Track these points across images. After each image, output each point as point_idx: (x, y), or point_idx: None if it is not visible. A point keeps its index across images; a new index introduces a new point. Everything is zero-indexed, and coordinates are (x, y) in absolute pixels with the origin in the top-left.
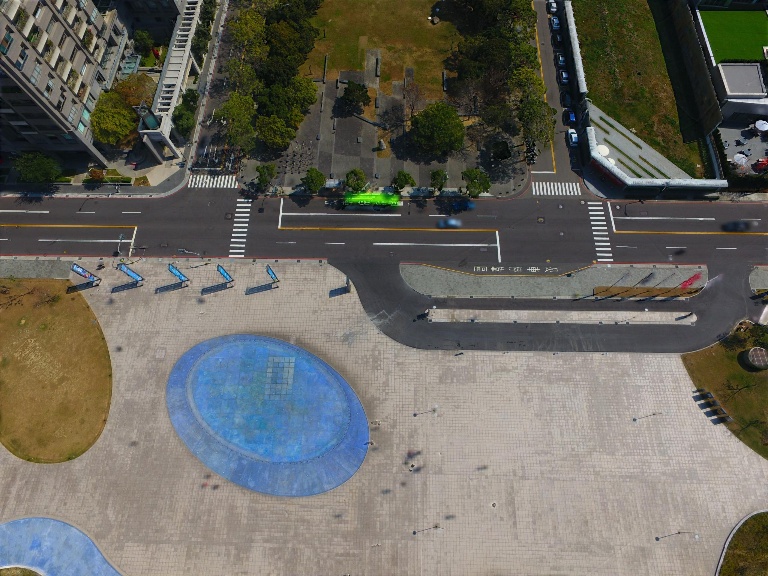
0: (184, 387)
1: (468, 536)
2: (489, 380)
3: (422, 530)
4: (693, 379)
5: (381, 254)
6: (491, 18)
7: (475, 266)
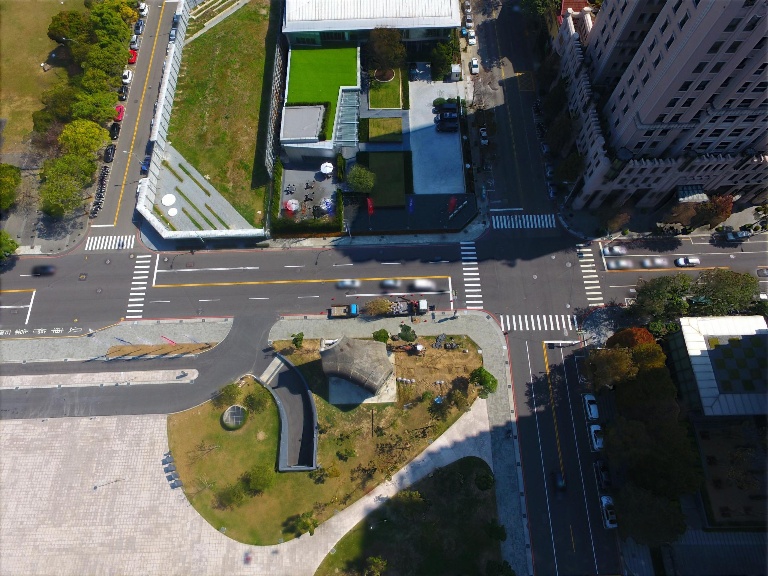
0: None
1: None
2: None
3: None
4: (169, 441)
5: None
6: None
7: None
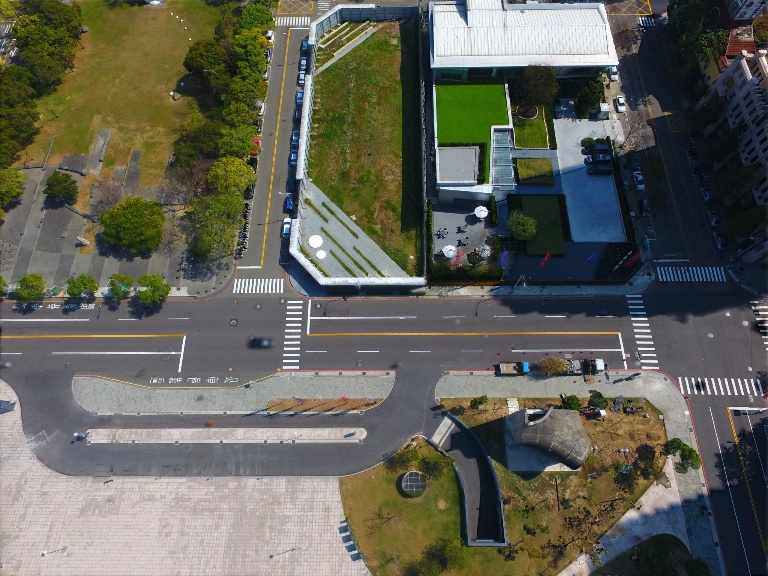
0: None
1: None
2: (132, 511)
3: None
4: (344, 507)
5: (57, 365)
6: None
7: (152, 377)
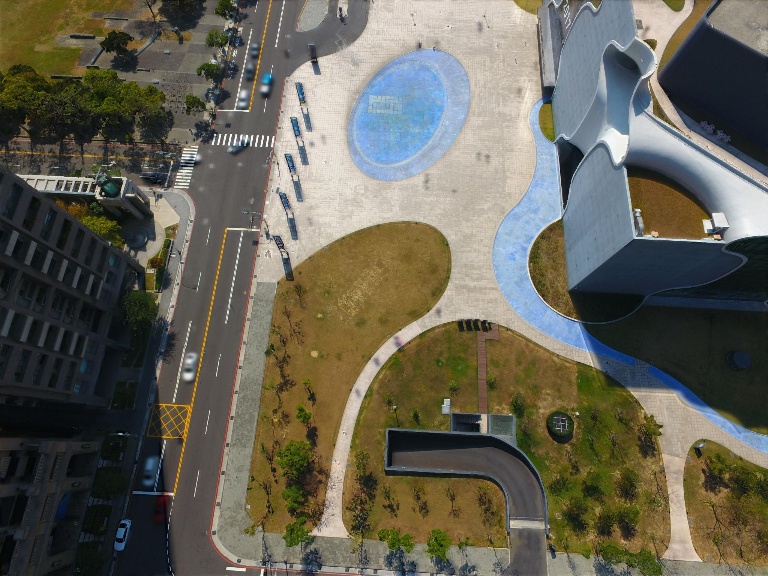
0: (390, 169)
1: (489, 2)
2: None
3: (487, 23)
4: None
5: (286, 42)
6: None
7: None
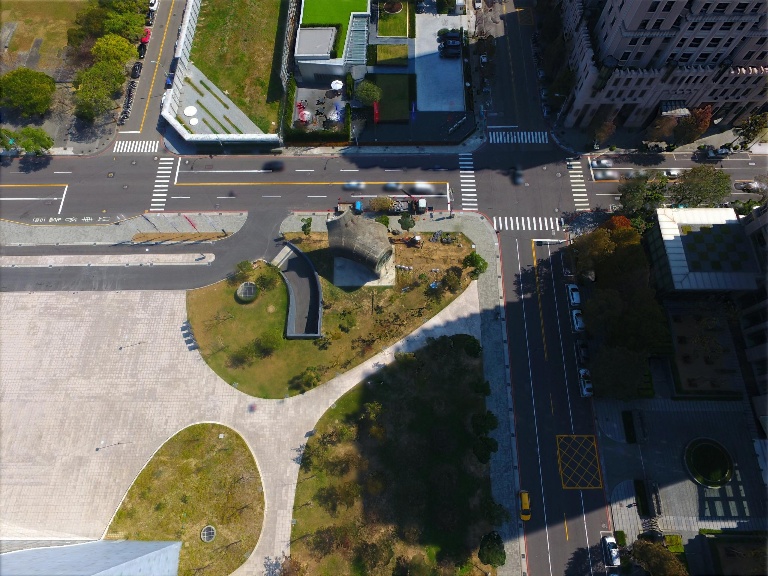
0: None
1: None
2: (6, 317)
3: None
4: (188, 312)
5: None
6: None
7: (35, 217)
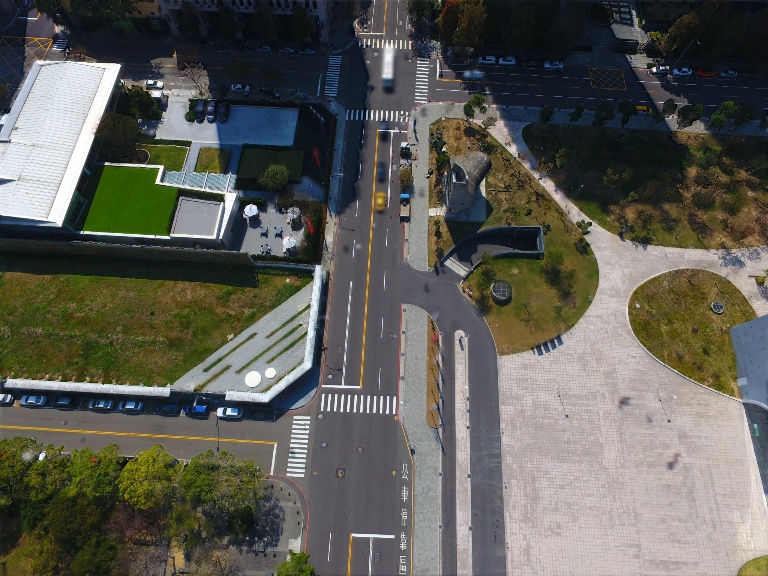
0: None
1: None
2: (541, 573)
3: None
4: (522, 351)
5: None
6: (0, 509)
7: (399, 573)
